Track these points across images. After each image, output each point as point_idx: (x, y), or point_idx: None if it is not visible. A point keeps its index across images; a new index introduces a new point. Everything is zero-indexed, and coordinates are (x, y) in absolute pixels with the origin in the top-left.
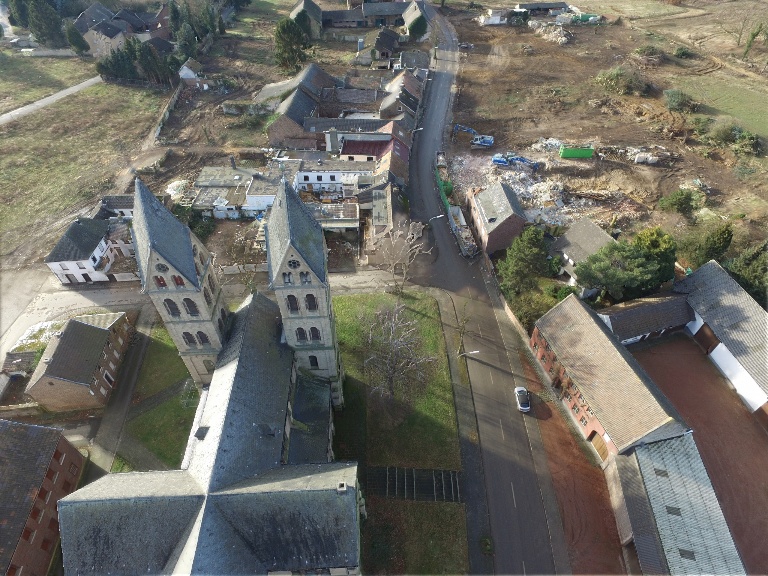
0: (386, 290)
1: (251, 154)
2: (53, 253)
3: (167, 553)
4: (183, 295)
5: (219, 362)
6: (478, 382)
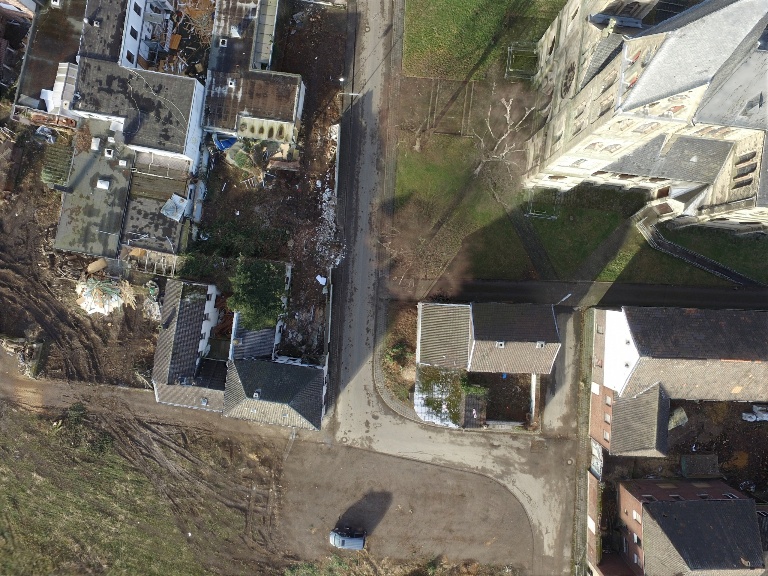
0: None
1: (11, 168)
2: (310, 419)
3: None
4: None
5: None
6: None
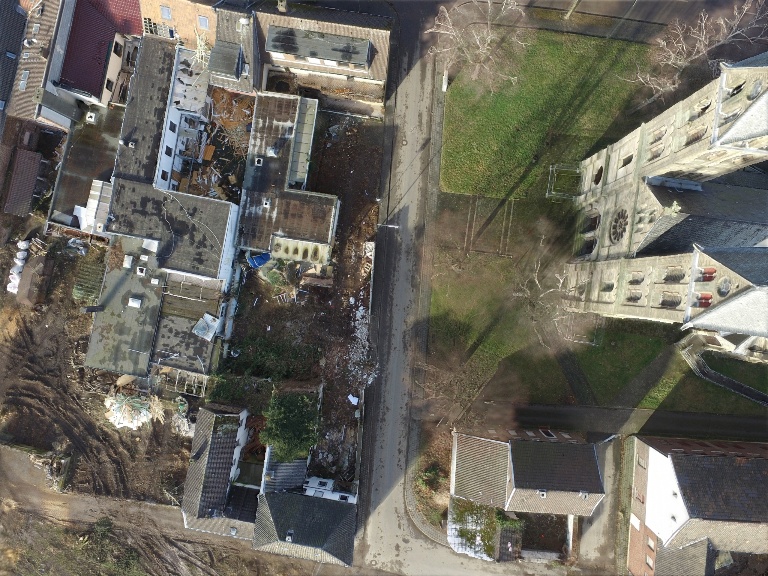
0: (446, 87)
1: (42, 282)
2: (343, 557)
3: None
4: None
5: None
6: (612, 7)
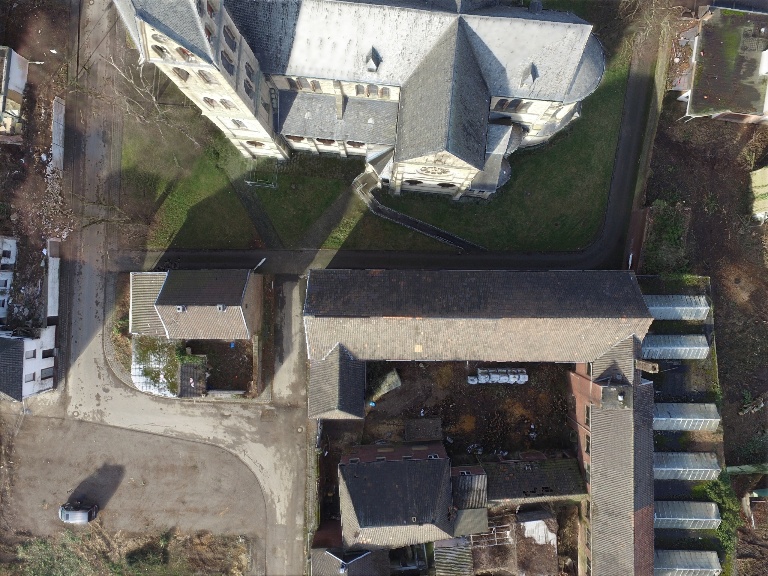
0: None
1: None
2: (5, 389)
3: (481, 79)
4: (221, 28)
5: (278, 65)
6: None
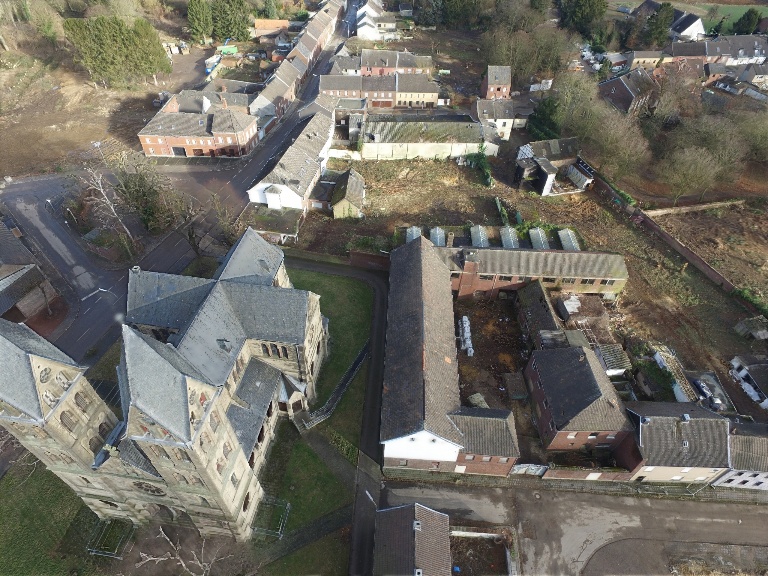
0: None
1: None
2: None
3: None
4: None
5: None
6: None
